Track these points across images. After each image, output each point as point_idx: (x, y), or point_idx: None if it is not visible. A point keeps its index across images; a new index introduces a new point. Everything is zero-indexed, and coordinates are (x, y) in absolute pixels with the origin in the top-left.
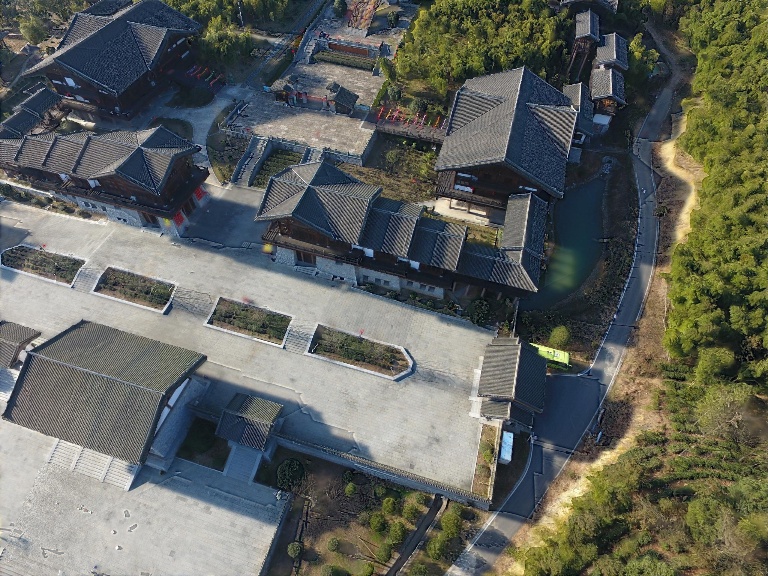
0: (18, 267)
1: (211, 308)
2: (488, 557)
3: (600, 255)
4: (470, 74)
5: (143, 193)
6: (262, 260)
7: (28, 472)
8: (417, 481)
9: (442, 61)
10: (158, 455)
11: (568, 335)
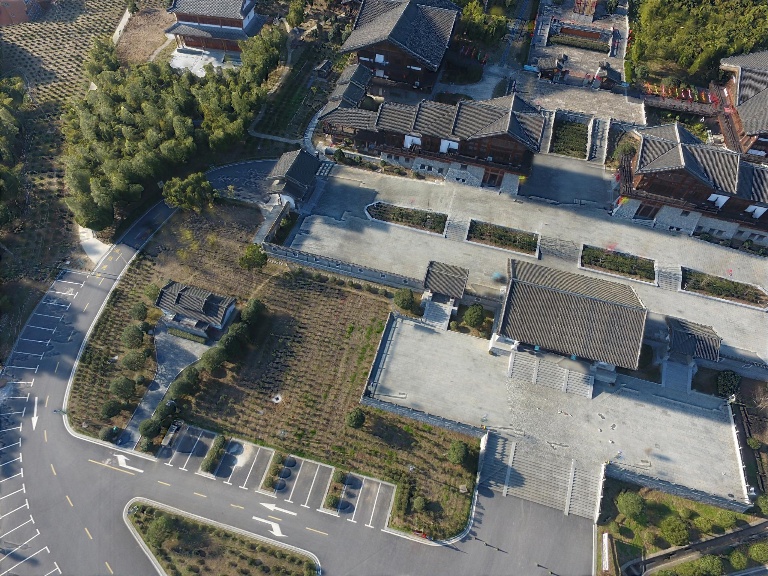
0: (387, 220)
1: (578, 254)
2: None
3: None
4: (717, 54)
5: (504, 153)
6: (600, 214)
7: (498, 385)
8: None
9: (691, 42)
10: (607, 370)
11: None
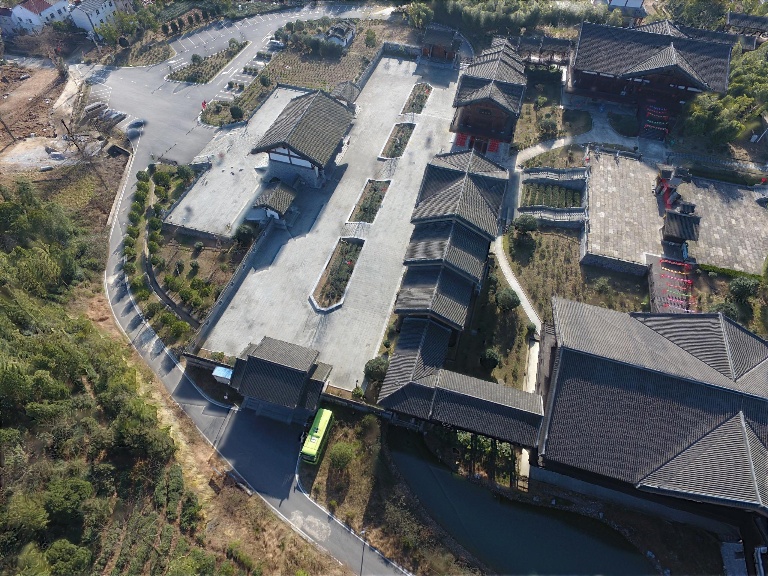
0: None
1: (382, 179)
2: (155, 362)
3: (501, 574)
4: None
5: None
6: None
7: None
8: None
9: None
10: None
11: (337, 456)
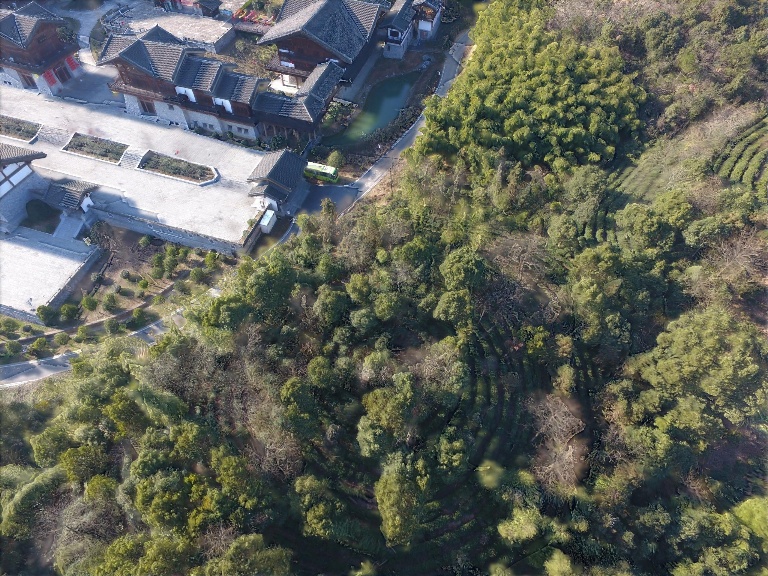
0: None
1: (68, 140)
2: None
3: None
4: None
5: (18, 53)
6: (116, 111)
7: None
8: (193, 236)
9: None
10: (4, 221)
11: (338, 156)
